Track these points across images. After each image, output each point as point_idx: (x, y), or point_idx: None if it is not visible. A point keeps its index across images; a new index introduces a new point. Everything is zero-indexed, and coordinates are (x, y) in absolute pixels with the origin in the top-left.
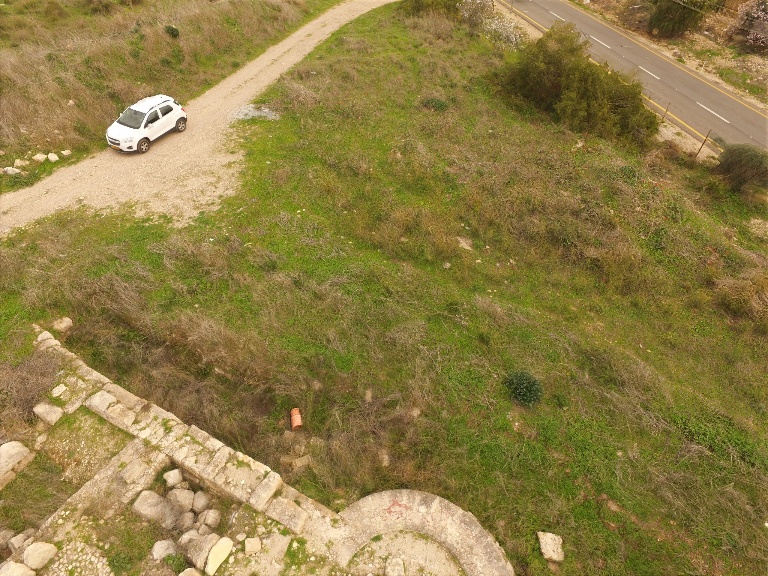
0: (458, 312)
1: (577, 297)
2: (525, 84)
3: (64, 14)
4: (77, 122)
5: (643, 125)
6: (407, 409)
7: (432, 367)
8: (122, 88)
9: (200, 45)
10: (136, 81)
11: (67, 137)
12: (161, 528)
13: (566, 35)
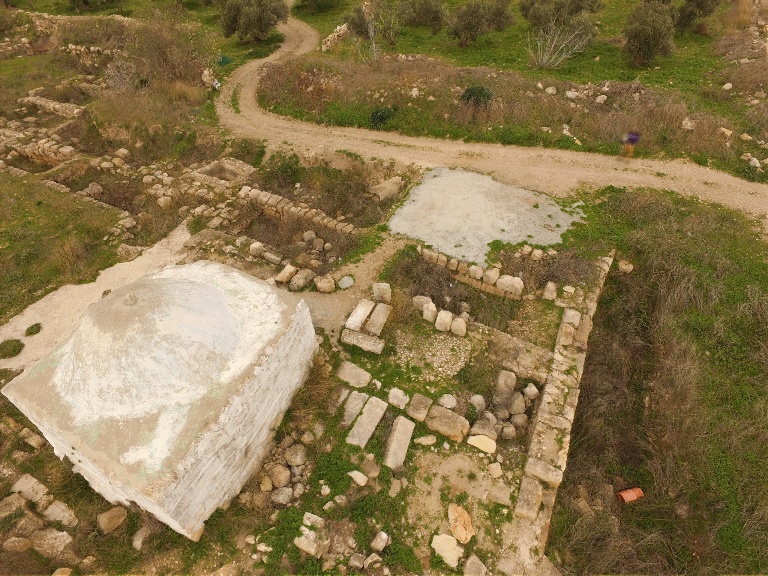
0: None
1: None
2: None
3: None
4: None
5: None
6: None
7: None
8: None
9: None
10: None
11: None
12: (492, 396)
13: None
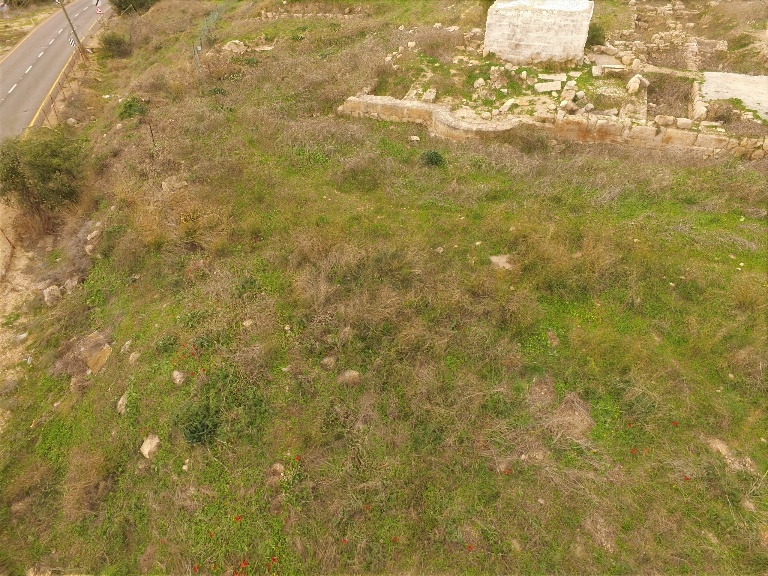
0: None
1: None
2: None
3: None
4: None
5: None
6: None
7: None
8: None
9: None
10: None
11: None
12: None
13: None
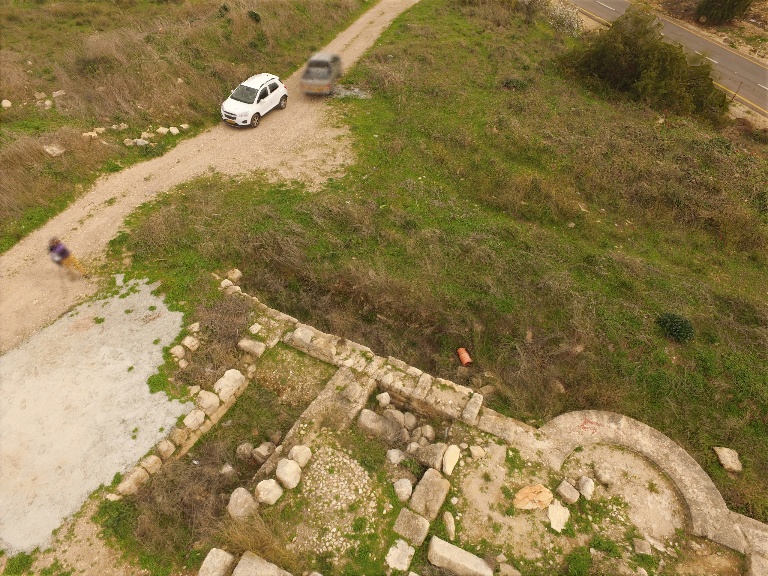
0: (596, 264)
1: (698, 252)
2: (599, 65)
3: (134, 2)
4: (190, 98)
5: (716, 103)
6: (572, 345)
7: (586, 310)
8: (223, 68)
9: (279, 30)
10: (230, 62)
11: (183, 112)
12: (387, 440)
13: (643, 17)
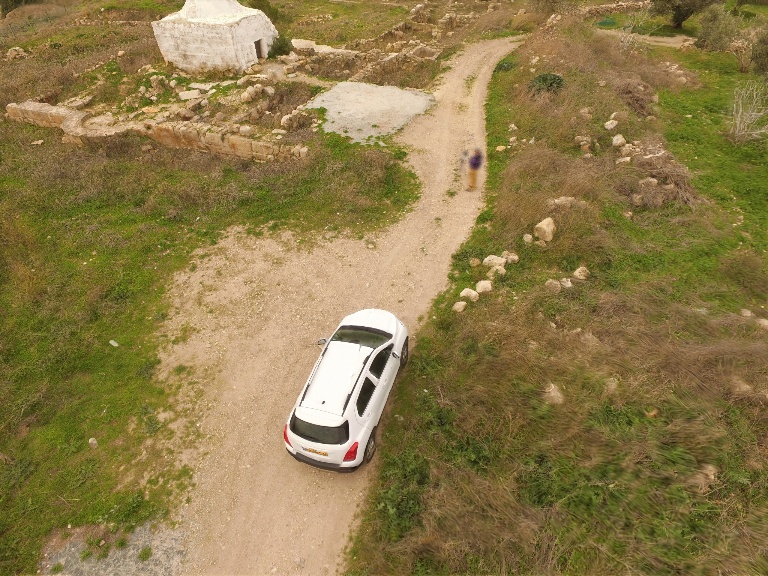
0: None
1: None
2: None
3: None
4: (487, 347)
5: None
6: None
7: None
8: (493, 494)
9: None
10: None
11: None
12: None
13: None
